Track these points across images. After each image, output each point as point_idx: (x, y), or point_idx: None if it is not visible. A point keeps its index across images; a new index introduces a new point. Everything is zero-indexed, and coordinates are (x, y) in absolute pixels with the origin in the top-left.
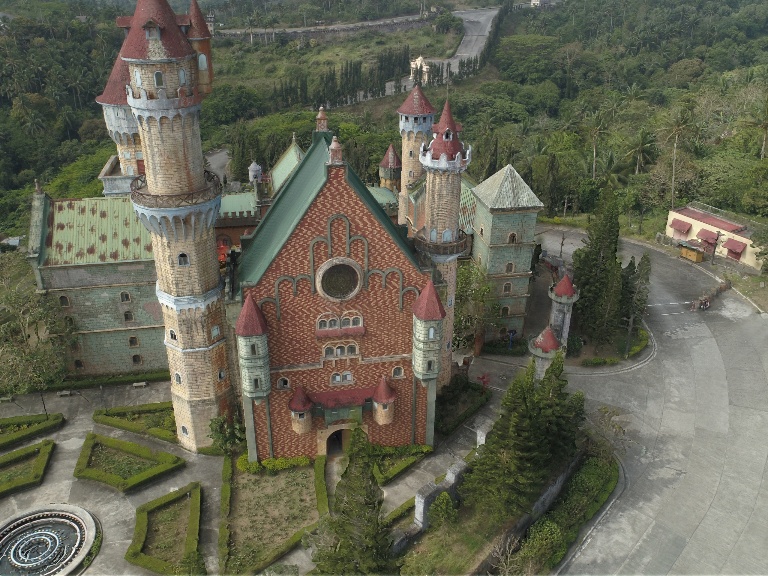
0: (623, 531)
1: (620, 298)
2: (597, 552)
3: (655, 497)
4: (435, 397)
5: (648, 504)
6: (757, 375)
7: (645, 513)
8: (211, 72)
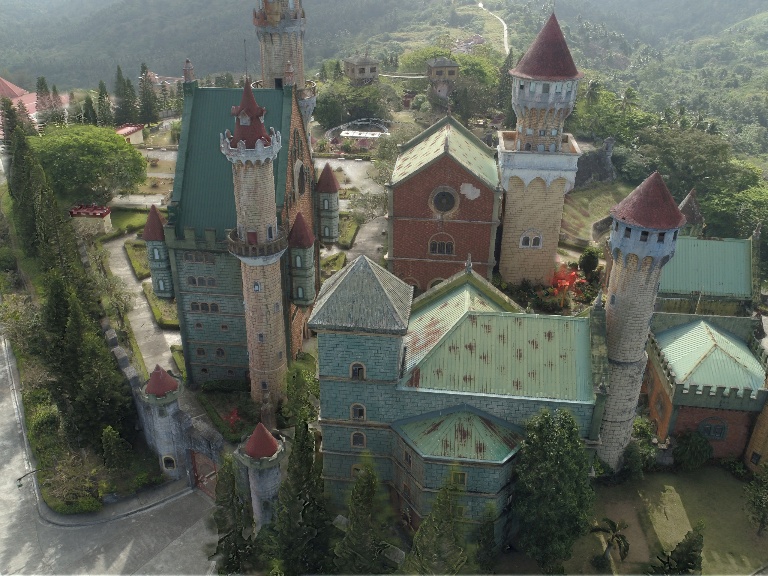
0: (8, 492)
1: (221, 521)
2: (13, 467)
3: (7, 534)
4: (181, 333)
5: (8, 524)
6: None
7: (3, 516)
8: (268, 5)
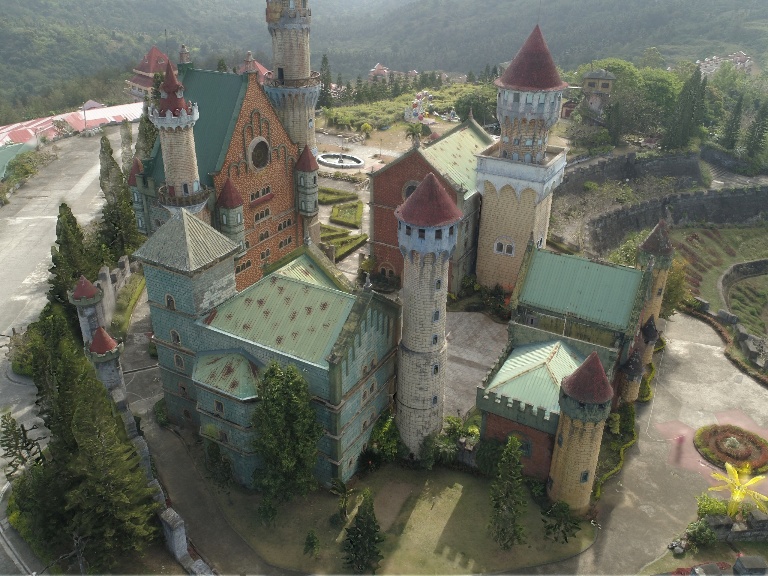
0: (3, 352)
1: (37, 386)
2: None
3: None
4: None
5: None
6: None
7: None
8: (268, 5)
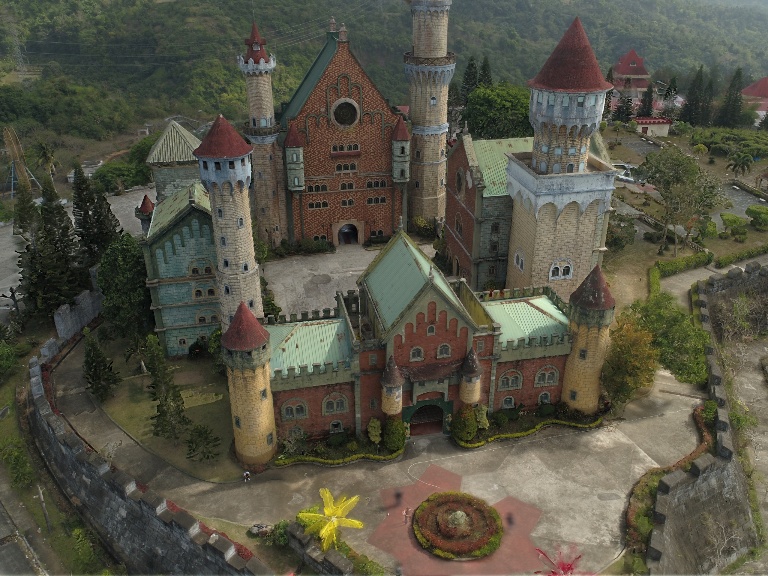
0: None
1: None
2: None
3: None
4: None
5: None
6: (5, 264)
7: None
8: None
